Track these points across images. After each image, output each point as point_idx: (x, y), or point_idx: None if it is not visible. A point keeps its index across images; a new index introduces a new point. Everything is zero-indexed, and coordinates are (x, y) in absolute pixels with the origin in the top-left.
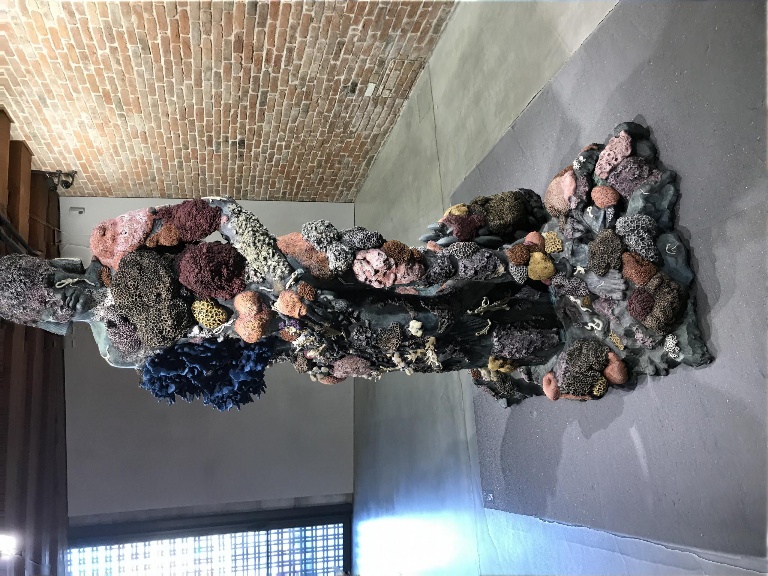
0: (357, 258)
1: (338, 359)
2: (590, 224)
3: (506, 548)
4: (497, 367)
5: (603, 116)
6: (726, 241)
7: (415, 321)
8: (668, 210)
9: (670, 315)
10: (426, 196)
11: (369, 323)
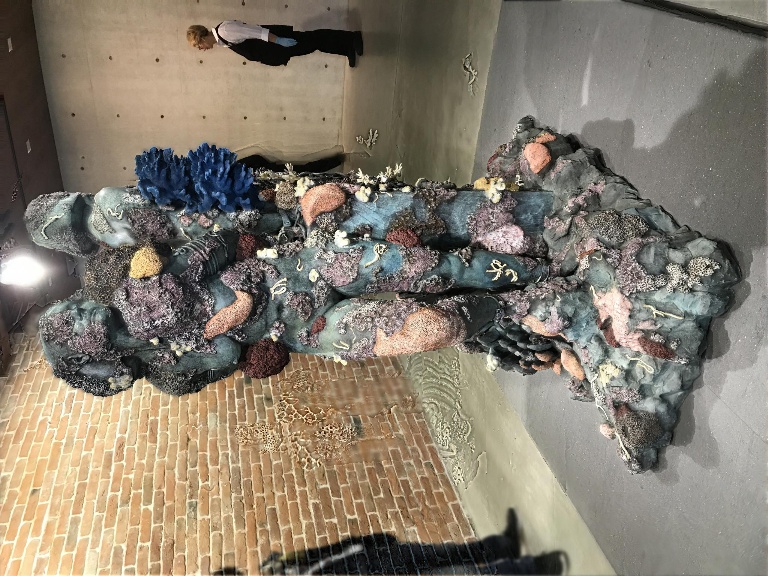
0: None
1: None
2: None
3: None
4: None
5: None
6: None
7: None
8: None
9: None
10: None
11: None
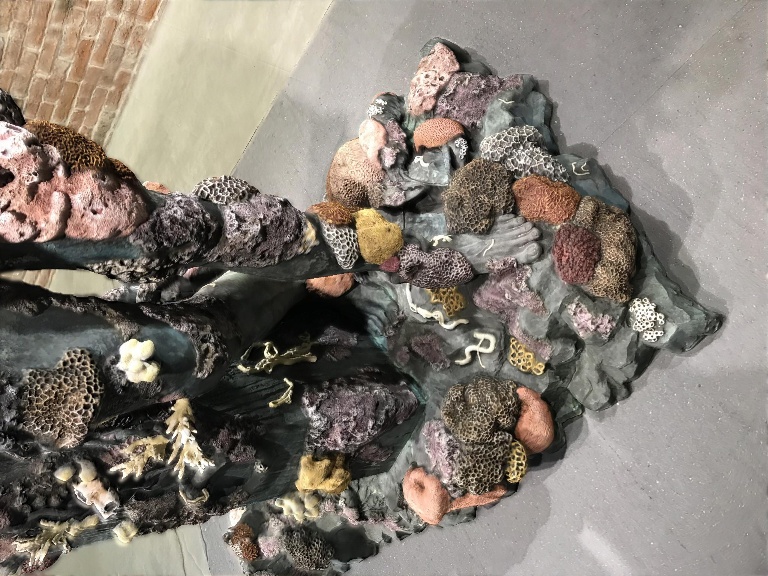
0: None
1: None
2: (427, 179)
3: None
4: (321, 476)
5: (381, 80)
6: (671, 120)
7: (134, 340)
8: (546, 126)
9: (634, 255)
10: None
11: None
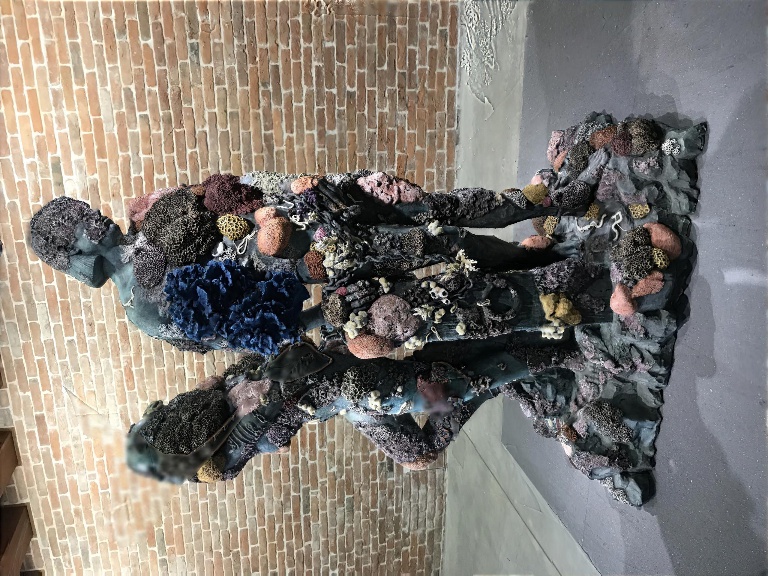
0: None
1: (372, 297)
2: (564, 178)
3: None
4: (551, 299)
5: None
6: (647, 77)
7: (432, 223)
8: None
9: (647, 127)
10: (494, 522)
11: None
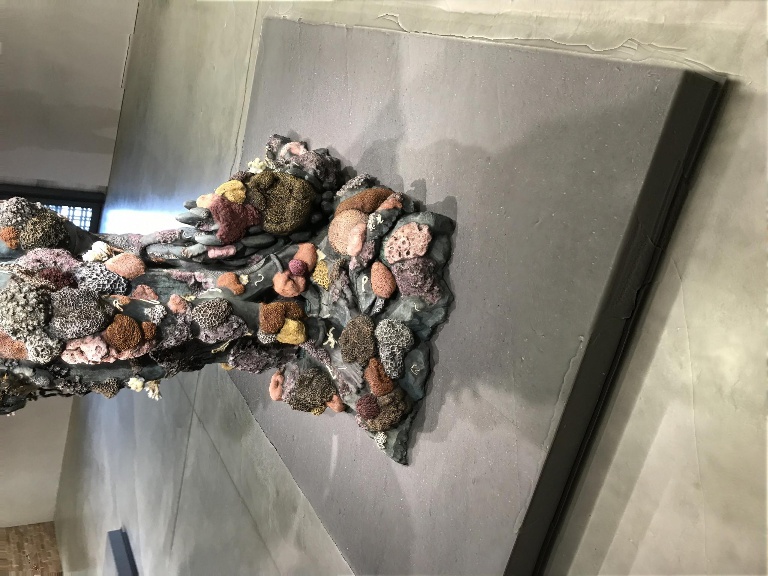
0: (68, 349)
1: None
2: (359, 294)
3: (225, 374)
4: None
5: (427, 152)
6: (458, 401)
7: (136, 380)
8: (431, 328)
9: (387, 428)
10: None
11: (80, 378)
